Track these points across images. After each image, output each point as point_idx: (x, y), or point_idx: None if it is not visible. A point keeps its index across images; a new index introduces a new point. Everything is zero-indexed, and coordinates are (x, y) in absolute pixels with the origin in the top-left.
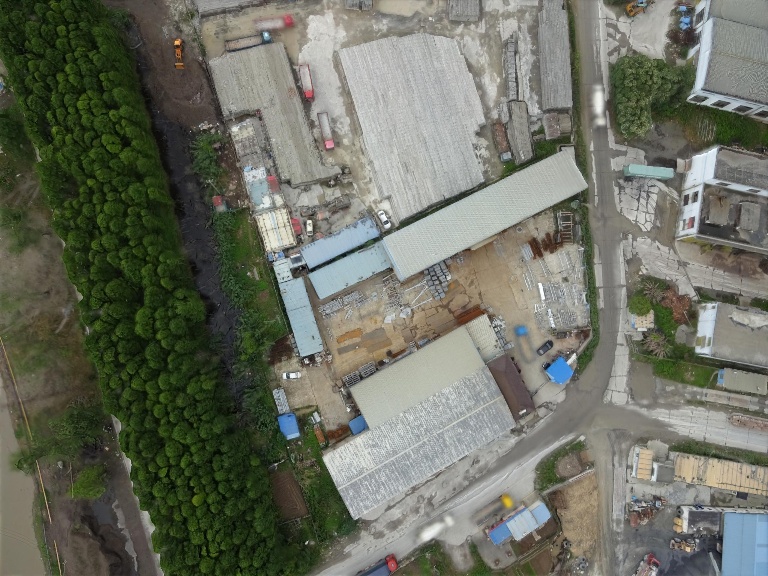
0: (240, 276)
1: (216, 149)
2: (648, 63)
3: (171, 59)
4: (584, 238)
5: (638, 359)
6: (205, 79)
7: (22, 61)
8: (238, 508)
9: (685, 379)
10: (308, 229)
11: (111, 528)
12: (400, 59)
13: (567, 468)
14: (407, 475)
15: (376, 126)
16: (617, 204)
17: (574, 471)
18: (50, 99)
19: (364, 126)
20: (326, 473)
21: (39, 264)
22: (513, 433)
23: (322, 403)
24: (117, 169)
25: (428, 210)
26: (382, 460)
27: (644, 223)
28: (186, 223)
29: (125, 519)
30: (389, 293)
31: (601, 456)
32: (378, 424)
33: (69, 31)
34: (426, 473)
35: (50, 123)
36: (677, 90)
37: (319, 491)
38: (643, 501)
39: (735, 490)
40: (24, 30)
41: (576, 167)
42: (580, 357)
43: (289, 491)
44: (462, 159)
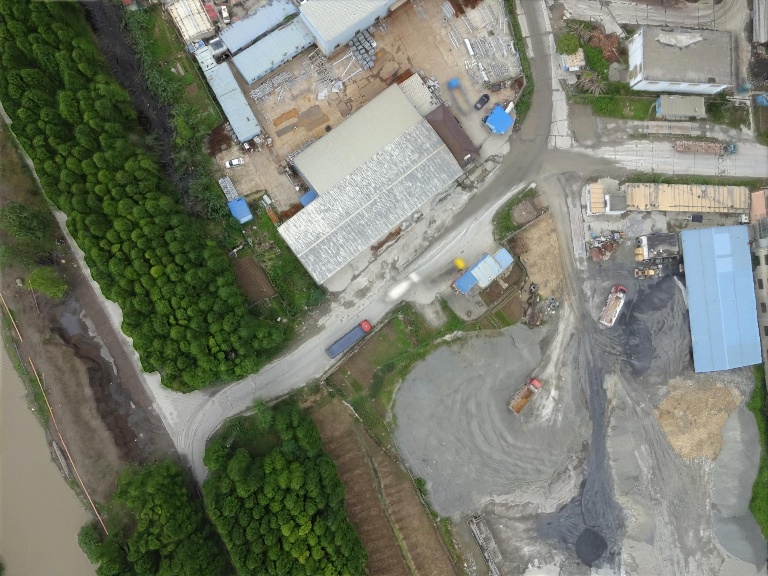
0: (164, 73)
1: None
2: None
3: None
4: None
5: (575, 101)
6: None
7: None
8: (199, 277)
9: (624, 115)
10: (224, 15)
11: (83, 337)
12: None
13: (522, 215)
14: (364, 234)
15: None
16: None
17: (530, 217)
18: None
19: None
20: (286, 253)
21: None
22: (464, 190)
23: (270, 187)
24: None
25: None
26: (337, 223)
27: None
28: (100, 29)
29: (95, 327)
30: (318, 70)
31: (554, 200)
32: (327, 189)
33: None
34: (382, 230)
35: None
36: None
37: (282, 270)
38: (602, 236)
39: (688, 211)
40: None
41: None
42: (518, 106)
43: (253, 275)
44: None
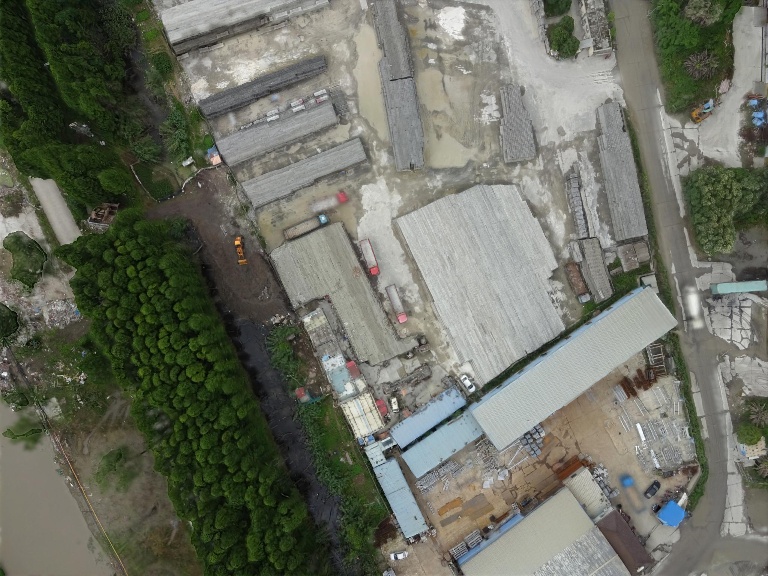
0: (334, 464)
1: (291, 340)
2: (725, 175)
3: (233, 256)
4: (679, 370)
5: (753, 486)
6: (270, 272)
7: (100, 312)
8: None
9: None
10: (394, 408)
11: None
12: (461, 217)
13: None
14: None
15: (446, 291)
16: (708, 325)
17: None
18: (132, 342)
19: (434, 293)
20: None
21: (142, 482)
22: None
23: None
24: (205, 399)
25: (511, 365)
26: None
27: (740, 341)
28: (273, 417)
29: None
30: (483, 457)
31: None
32: None
33: (138, 271)
34: None
35: (135, 364)
36: (760, 197)
37: None
38: None
39: None
40: (97, 279)
41: (662, 304)
42: (691, 494)
43: None
44: (539, 310)
